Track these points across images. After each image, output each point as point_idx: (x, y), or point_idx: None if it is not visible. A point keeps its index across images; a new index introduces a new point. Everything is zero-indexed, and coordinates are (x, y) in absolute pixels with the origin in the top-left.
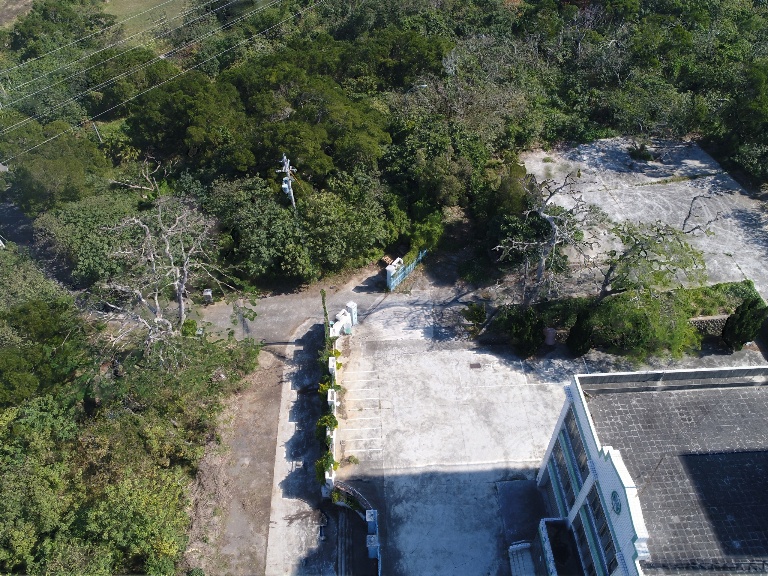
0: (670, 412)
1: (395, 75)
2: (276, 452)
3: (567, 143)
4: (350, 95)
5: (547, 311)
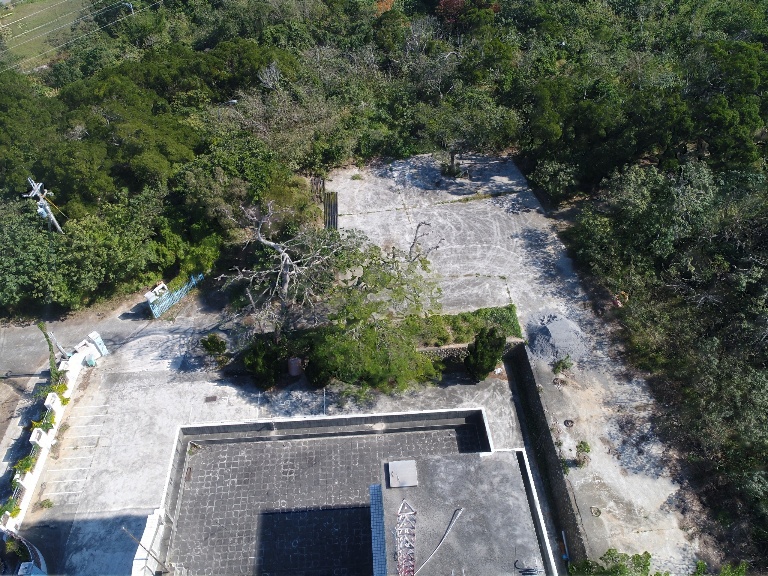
0: (275, 464)
1: (229, 88)
2: None
3: (383, 159)
4: (178, 109)
5: (300, 339)
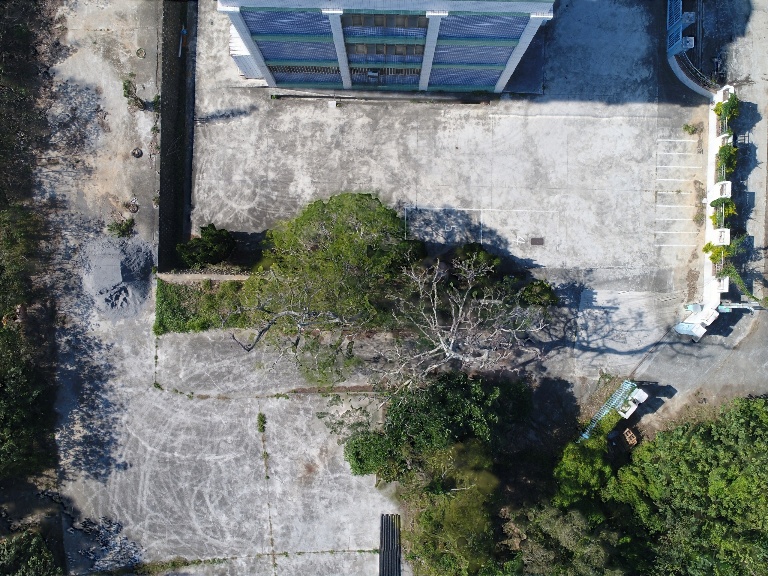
0: None
1: None
2: (767, 156)
3: None
4: None
5: None
